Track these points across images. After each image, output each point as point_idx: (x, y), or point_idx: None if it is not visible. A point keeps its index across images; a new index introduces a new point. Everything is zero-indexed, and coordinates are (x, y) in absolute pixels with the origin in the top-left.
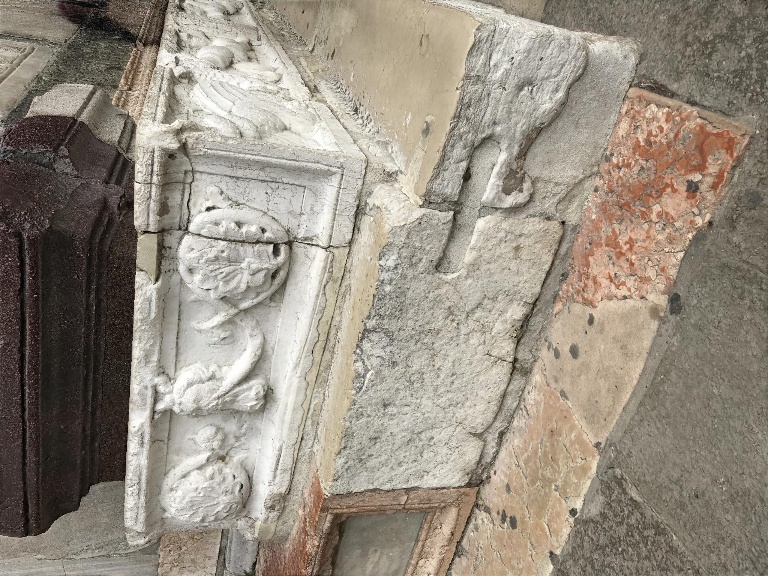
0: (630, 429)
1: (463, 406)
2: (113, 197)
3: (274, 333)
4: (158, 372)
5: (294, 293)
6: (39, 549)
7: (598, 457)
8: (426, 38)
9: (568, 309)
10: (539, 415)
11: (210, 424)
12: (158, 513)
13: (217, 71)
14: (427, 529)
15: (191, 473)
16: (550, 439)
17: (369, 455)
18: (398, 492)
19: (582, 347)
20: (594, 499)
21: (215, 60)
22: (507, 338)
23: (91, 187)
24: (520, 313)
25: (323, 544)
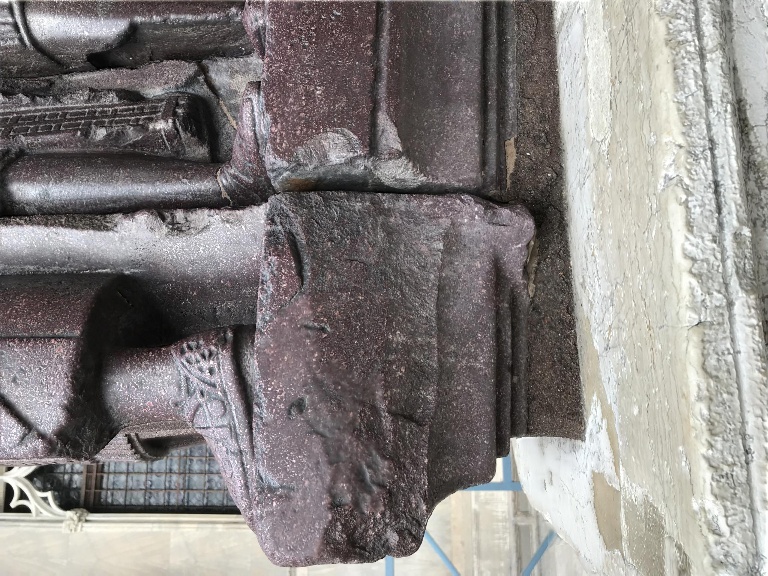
0: None
1: None
2: (512, 249)
3: None
4: None
5: None
6: None
7: None
8: None
9: None
10: None
11: None
12: None
13: None
14: None
15: None
16: None
17: None
18: None
19: None
20: None
21: None
22: None
23: (463, 233)
24: None
25: None
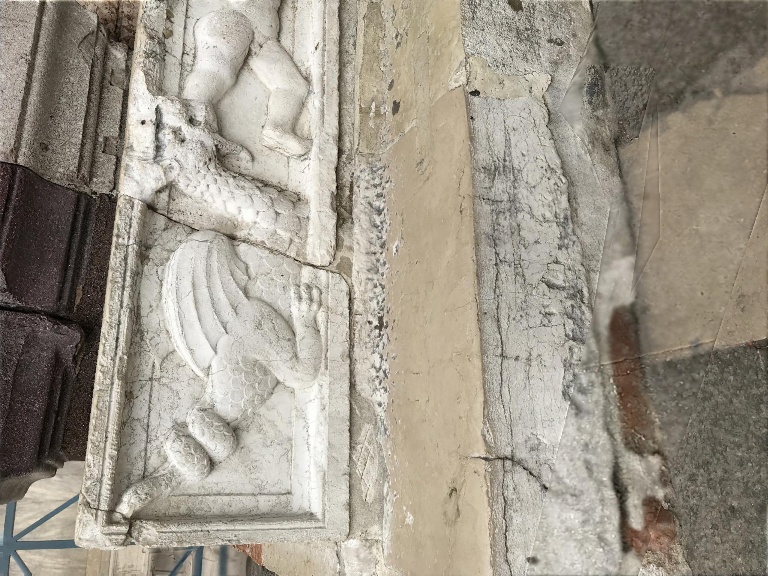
0: None
1: None
2: (66, 347)
3: None
4: None
5: None
6: None
7: None
8: (456, 510)
9: None
10: None
11: None
12: None
13: (212, 180)
14: None
15: None
16: None
17: None
18: None
19: None
20: None
21: (220, 81)
22: None
23: (39, 336)
24: None
25: None
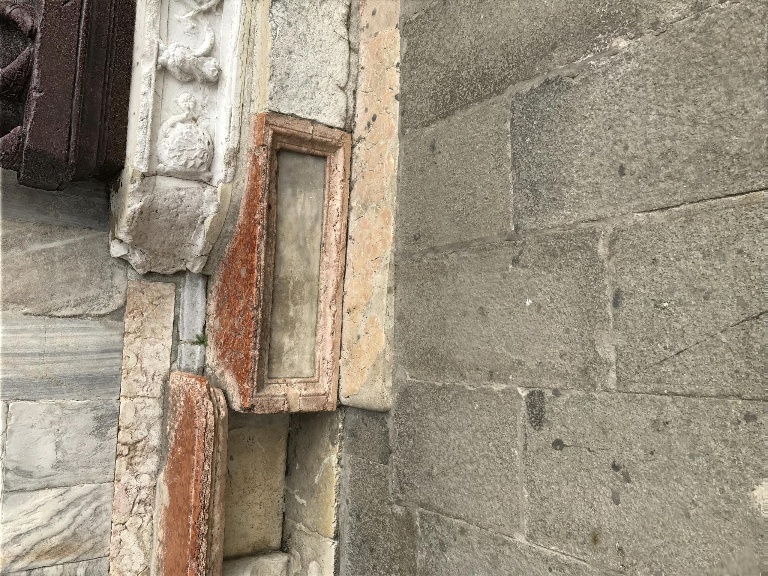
0: (405, 0)
1: (330, 64)
2: None
3: (219, 33)
4: (159, 37)
5: (228, 7)
6: (27, 301)
7: (399, 30)
8: None
9: (366, 4)
10: (369, 58)
11: (186, 92)
12: (155, 161)
13: None
14: (329, 171)
15: (177, 125)
16: (377, 57)
17: (286, 85)
18: (307, 122)
19: (377, 5)
20: (403, 45)
21: None
22: (342, 24)
23: None
24: (345, 10)
25: (270, 156)
